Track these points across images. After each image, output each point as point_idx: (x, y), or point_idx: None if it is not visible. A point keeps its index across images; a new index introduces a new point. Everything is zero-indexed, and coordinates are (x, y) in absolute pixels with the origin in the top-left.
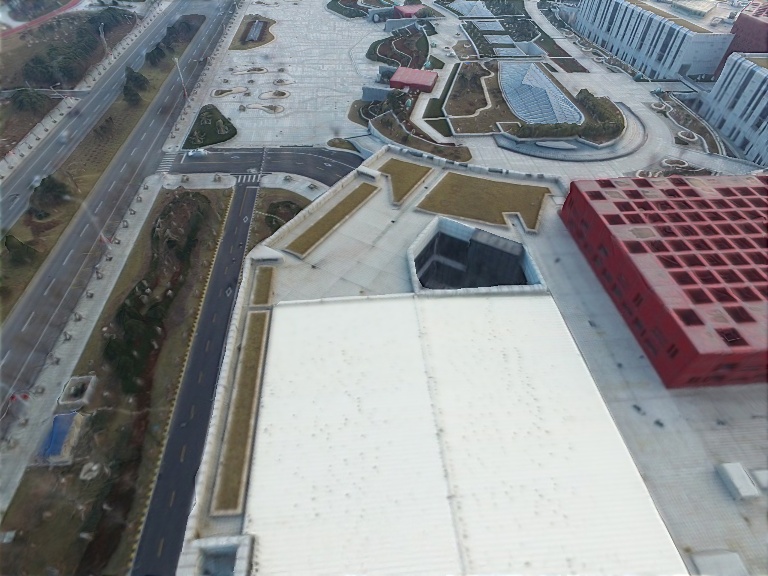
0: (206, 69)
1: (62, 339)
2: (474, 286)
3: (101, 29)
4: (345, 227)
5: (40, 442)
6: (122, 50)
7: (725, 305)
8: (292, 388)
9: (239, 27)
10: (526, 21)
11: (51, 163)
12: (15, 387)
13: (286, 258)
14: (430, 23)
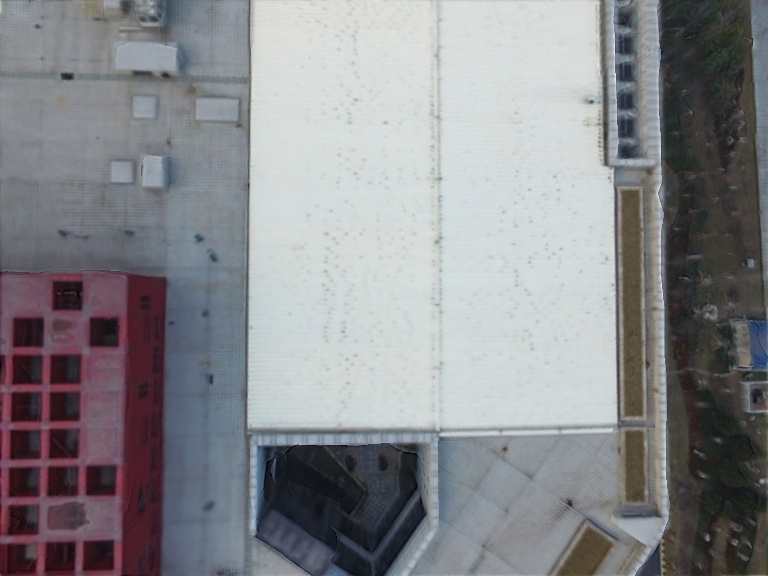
0: None
1: None
2: (316, 510)
3: None
4: None
5: (766, 343)
6: None
7: (37, 350)
8: (586, 304)
9: None
10: None
11: None
12: None
13: (610, 521)
14: None
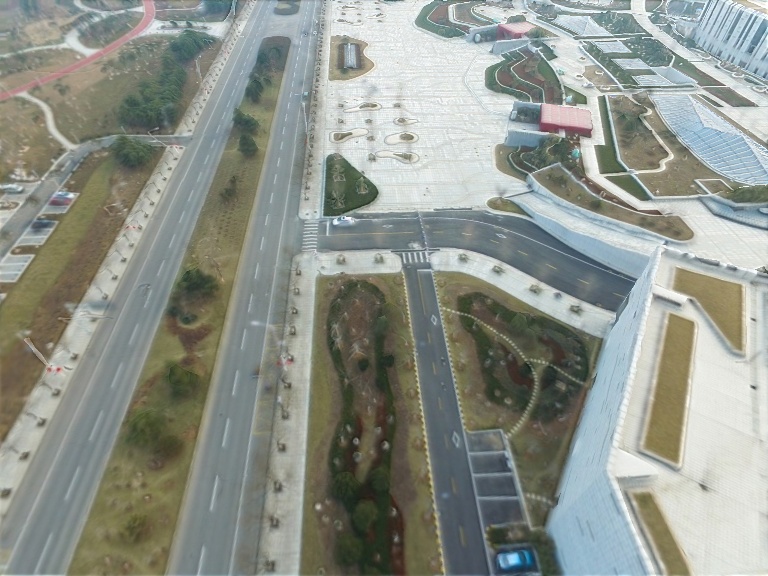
0: (313, 106)
1: (267, 524)
2: None
3: (198, 62)
4: (696, 401)
5: None
6: (213, 82)
7: None
8: None
9: (330, 51)
10: (652, 40)
11: (175, 237)
12: None
13: None
14: (546, 45)
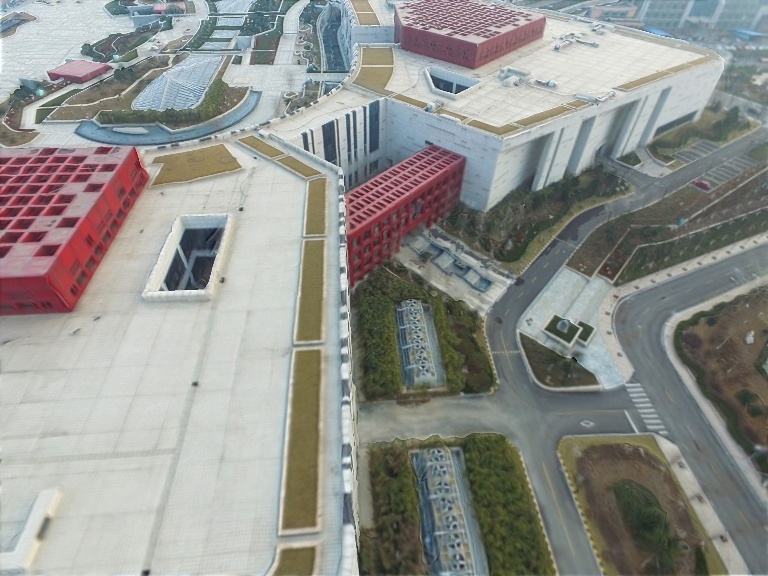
0: None
1: None
2: None
3: None
4: None
5: None
6: None
7: None
8: None
9: None
10: (271, 17)
11: None
12: None
13: None
14: (170, 19)
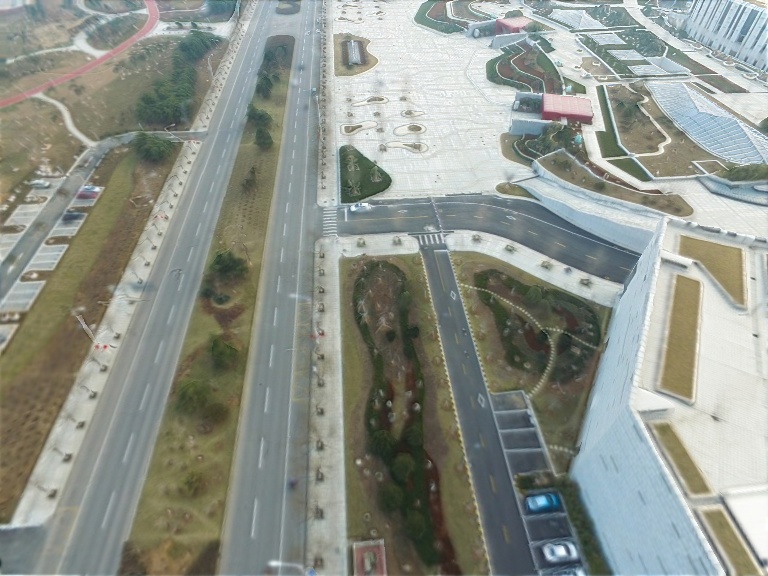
0: (322, 100)
1: (313, 478)
2: None
3: (209, 60)
4: (705, 348)
5: None
6: (223, 80)
7: None
8: None
9: (334, 48)
10: (645, 32)
11: (201, 226)
12: (283, 556)
13: None
14: (544, 38)
